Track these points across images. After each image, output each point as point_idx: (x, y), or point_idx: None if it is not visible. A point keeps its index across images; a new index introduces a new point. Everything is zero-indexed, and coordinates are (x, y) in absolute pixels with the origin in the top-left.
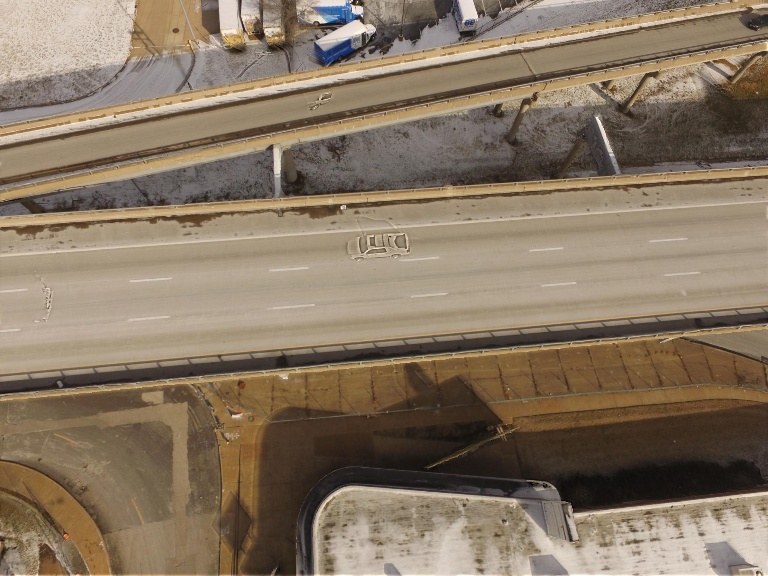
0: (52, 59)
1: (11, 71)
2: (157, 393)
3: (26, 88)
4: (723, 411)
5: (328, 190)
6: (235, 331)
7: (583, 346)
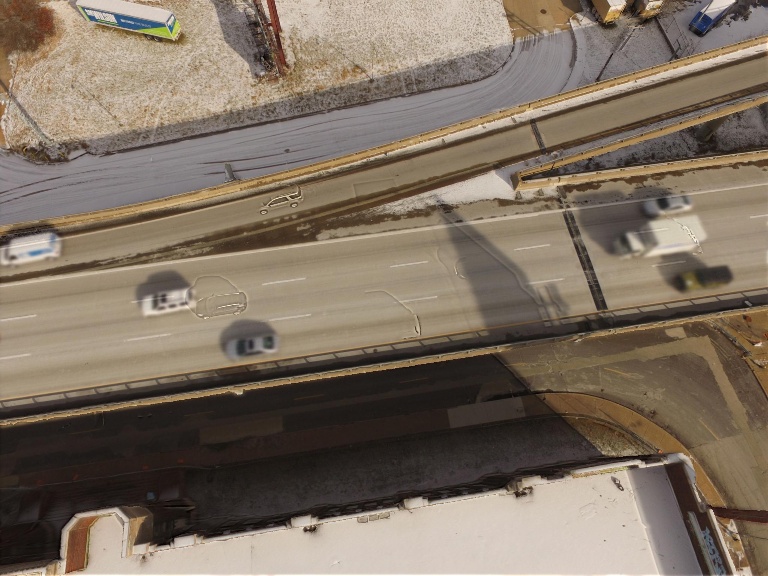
0: (448, 44)
1: (418, 56)
2: (678, 329)
3: (437, 71)
4: None
5: (740, 146)
6: None
7: None
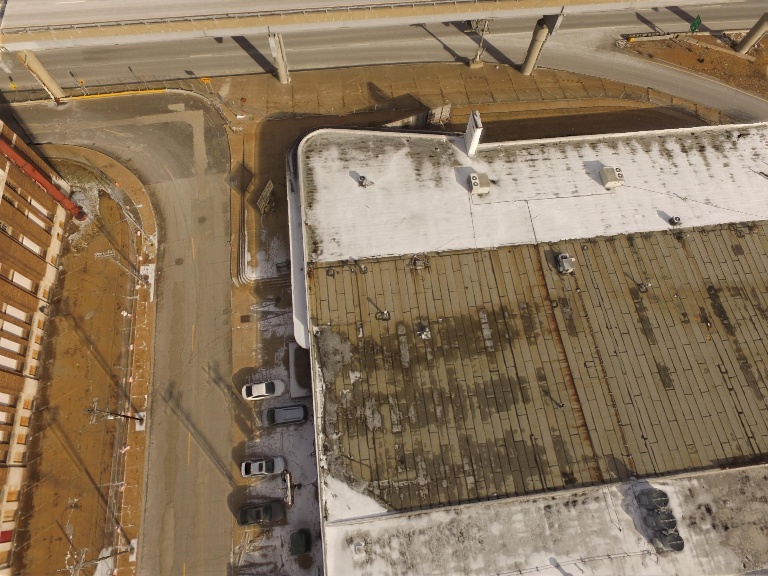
0: None
1: None
2: (180, 105)
3: None
4: (612, 112)
5: None
6: (238, 1)
7: (507, 77)
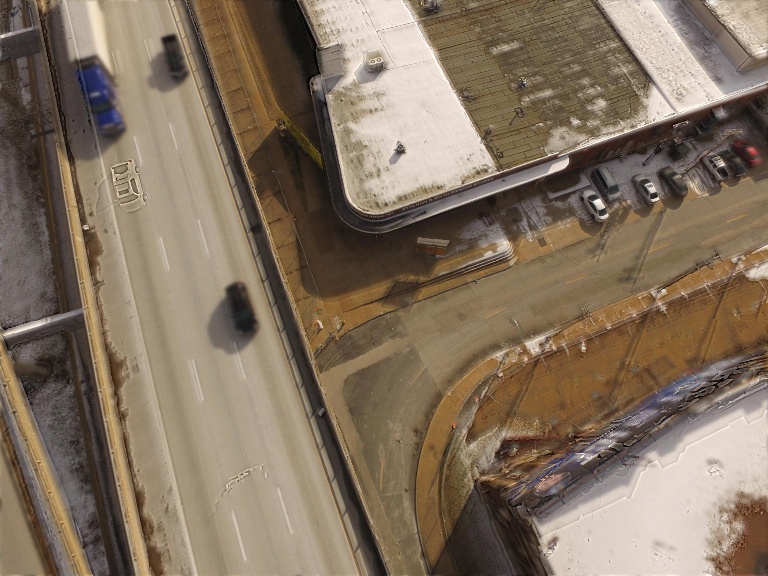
0: None
1: None
2: None
3: None
4: (235, 1)
5: None
6: (237, 277)
7: None
